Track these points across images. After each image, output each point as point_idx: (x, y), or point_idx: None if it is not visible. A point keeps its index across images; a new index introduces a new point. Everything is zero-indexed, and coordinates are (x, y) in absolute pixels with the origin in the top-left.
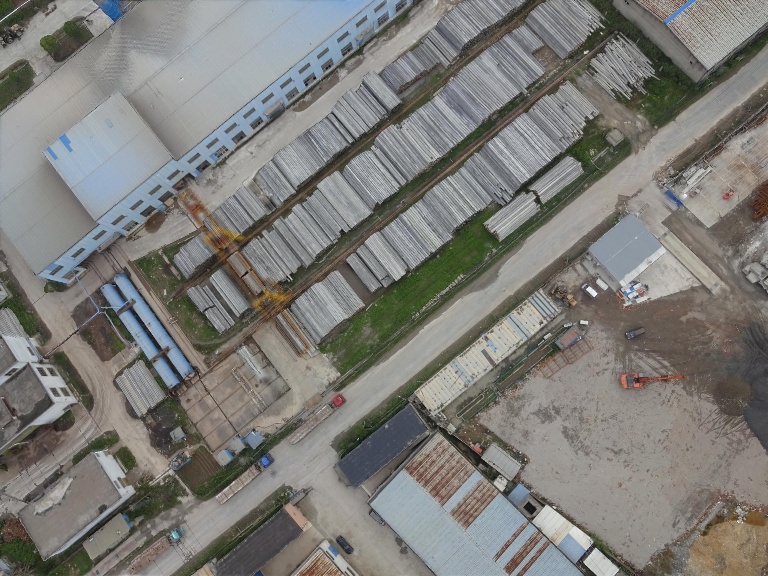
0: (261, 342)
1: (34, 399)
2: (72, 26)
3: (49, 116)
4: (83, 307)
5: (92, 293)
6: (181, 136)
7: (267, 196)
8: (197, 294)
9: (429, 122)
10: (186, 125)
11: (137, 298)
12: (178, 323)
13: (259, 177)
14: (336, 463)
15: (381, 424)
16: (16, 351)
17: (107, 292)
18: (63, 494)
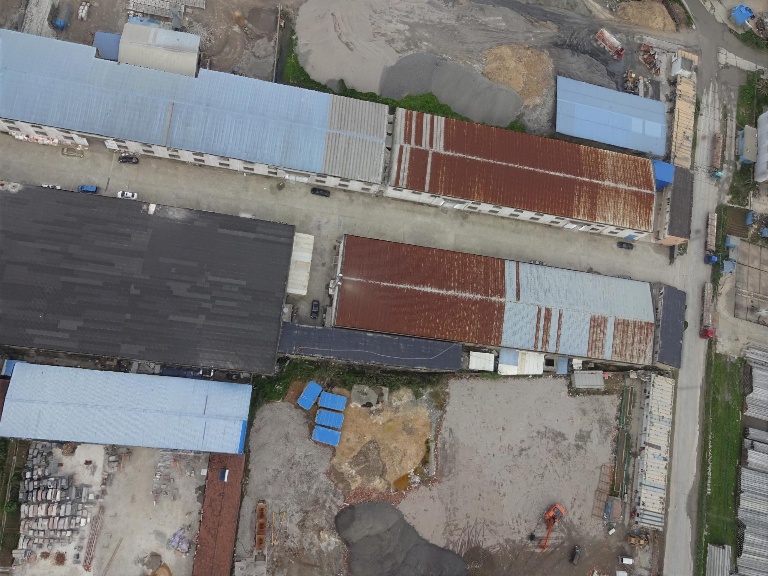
0: None
1: None
2: None
3: None
4: None
5: None
6: None
7: None
8: None
9: None
10: None
11: None
12: None
13: None
14: None
15: None
16: None
17: None
18: None
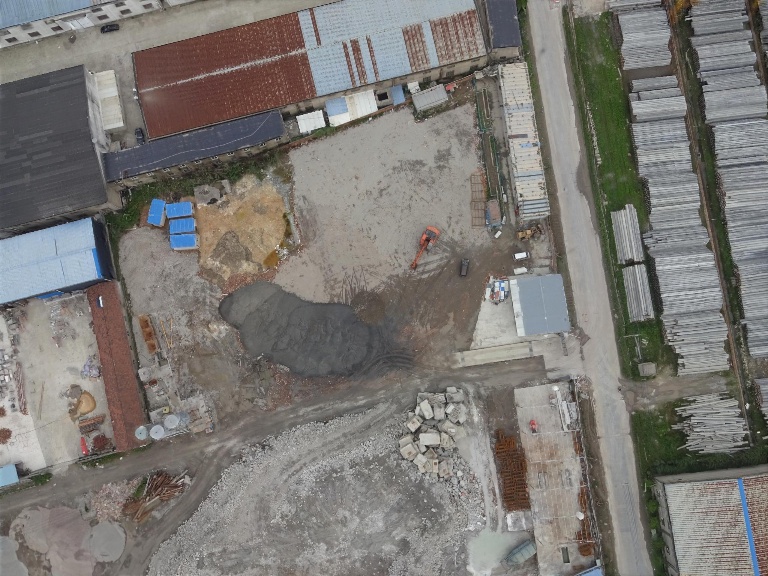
0: None
1: None
2: None
3: None
4: None
5: None
6: None
7: None
8: None
9: (767, 218)
10: None
11: None
12: None
13: None
14: None
15: None
16: None
17: None
18: None
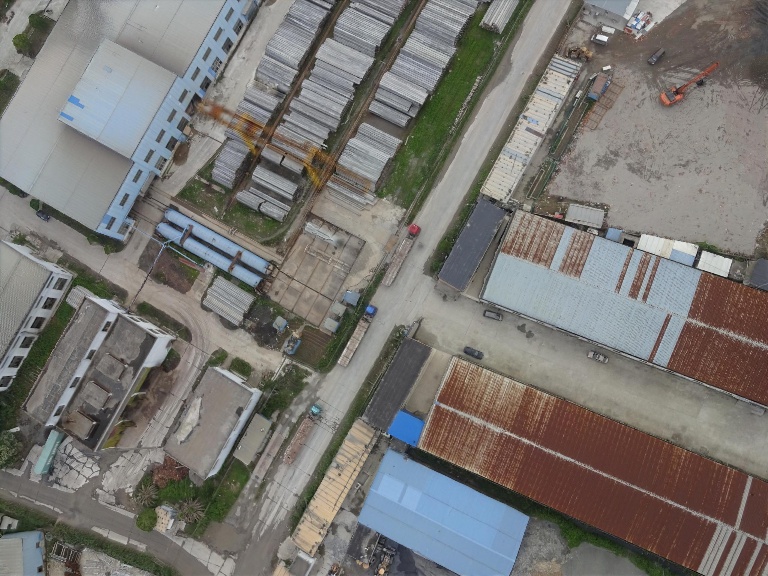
0: (322, 213)
1: (137, 343)
2: (36, 17)
3: (50, 91)
4: (146, 255)
5: (149, 240)
6: (177, 56)
7: (273, 88)
8: (246, 195)
9: None
10: (177, 44)
11: (193, 223)
12: (239, 231)
13: (259, 74)
14: None
15: None
16: (104, 306)
17: (163, 229)
18: (198, 415)
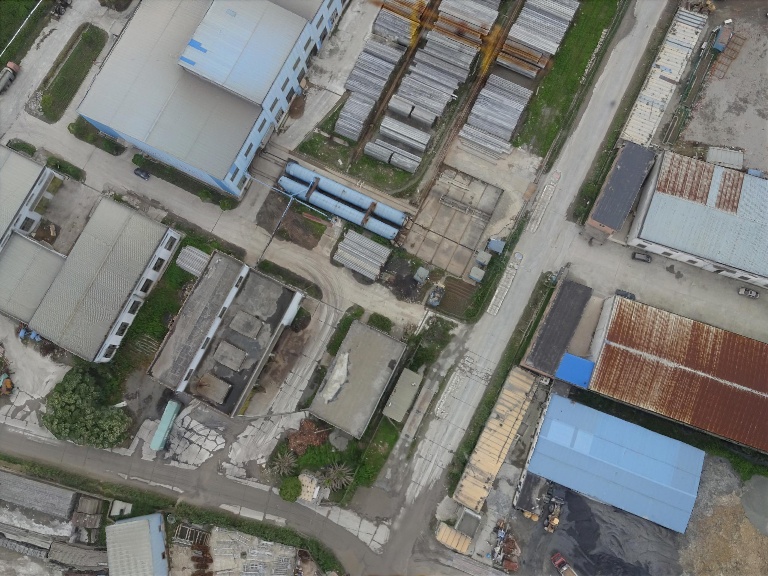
0: (455, 164)
1: (273, 298)
2: None
3: (161, 37)
4: (265, 212)
5: (267, 195)
6: (303, 1)
7: (393, 41)
8: (376, 146)
9: None
10: None
11: (319, 175)
12: (367, 184)
13: (378, 27)
14: (580, 232)
15: (603, 179)
16: None
17: (287, 182)
18: (346, 371)
